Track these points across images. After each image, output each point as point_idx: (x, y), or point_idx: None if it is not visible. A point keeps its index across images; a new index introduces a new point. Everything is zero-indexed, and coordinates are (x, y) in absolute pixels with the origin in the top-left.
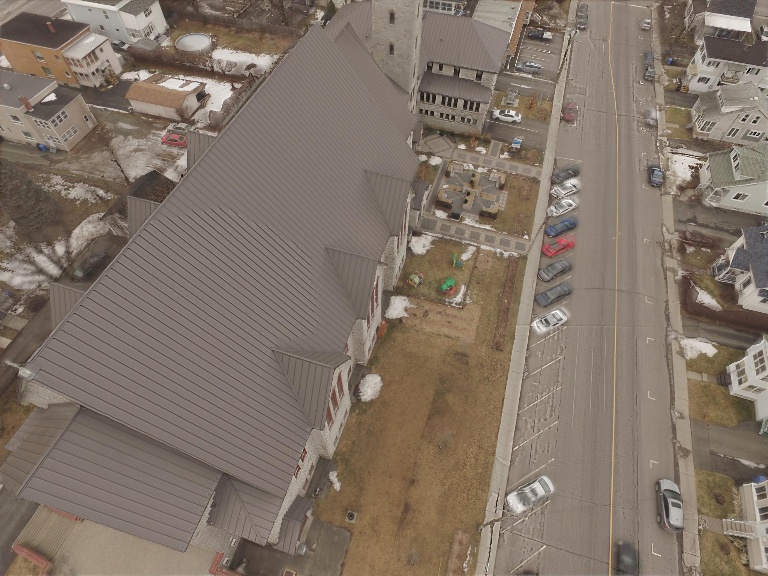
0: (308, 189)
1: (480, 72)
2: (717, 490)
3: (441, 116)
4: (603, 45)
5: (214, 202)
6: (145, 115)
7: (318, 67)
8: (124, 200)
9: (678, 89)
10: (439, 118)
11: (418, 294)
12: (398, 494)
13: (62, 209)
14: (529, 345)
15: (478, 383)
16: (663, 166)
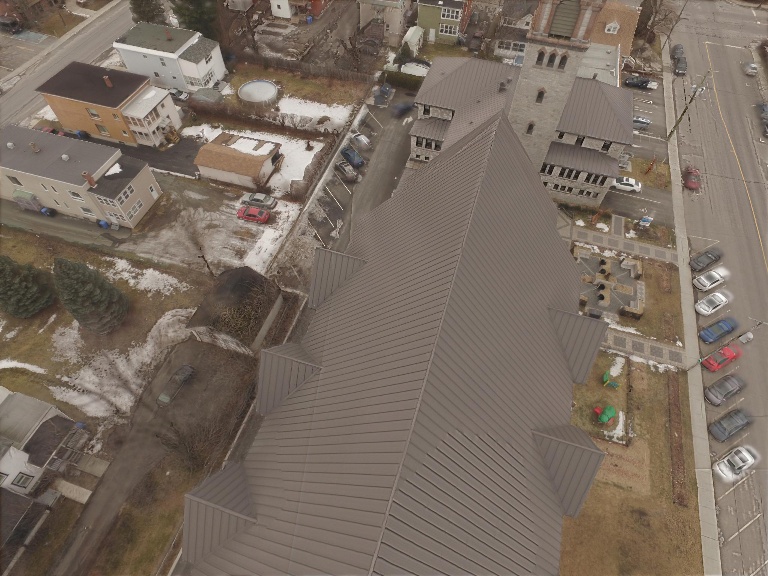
0: (512, 359)
1: (608, 142)
2: None
3: (555, 187)
4: (709, 94)
5: (443, 428)
6: (214, 181)
7: (503, 187)
8: (216, 307)
9: None
10: (552, 189)
11: None
12: None
13: (132, 304)
14: (716, 497)
15: (668, 555)
16: None
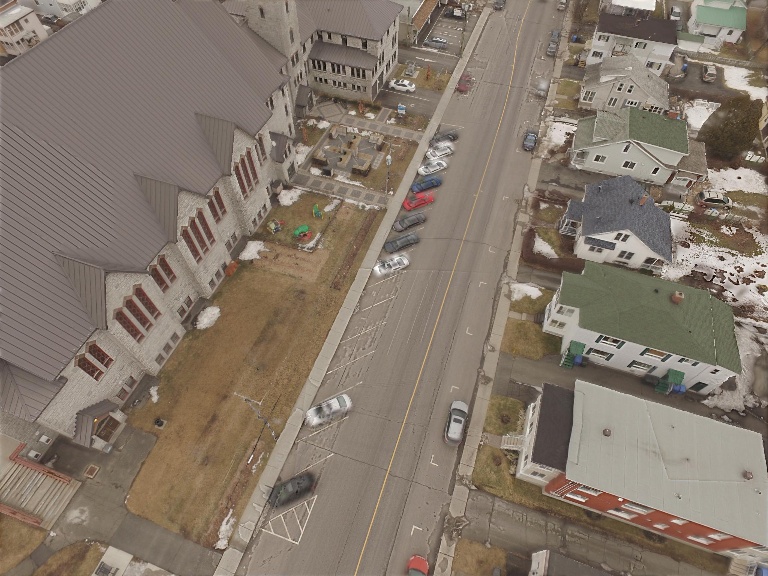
0: (118, 121)
1: (365, 40)
2: (505, 412)
3: (334, 84)
4: (515, 24)
5: None
6: None
7: (145, 15)
8: None
9: (576, 64)
10: (333, 86)
11: (274, 240)
12: (209, 407)
13: None
14: (367, 286)
15: (309, 316)
16: (541, 133)
